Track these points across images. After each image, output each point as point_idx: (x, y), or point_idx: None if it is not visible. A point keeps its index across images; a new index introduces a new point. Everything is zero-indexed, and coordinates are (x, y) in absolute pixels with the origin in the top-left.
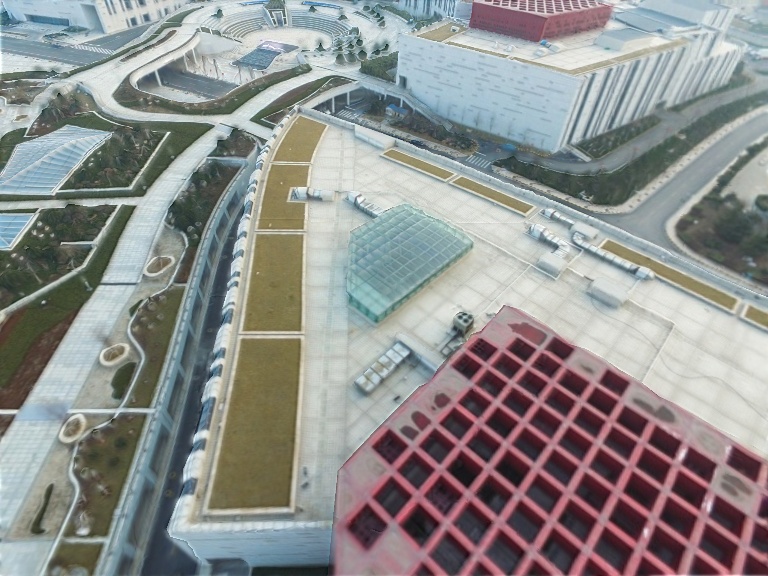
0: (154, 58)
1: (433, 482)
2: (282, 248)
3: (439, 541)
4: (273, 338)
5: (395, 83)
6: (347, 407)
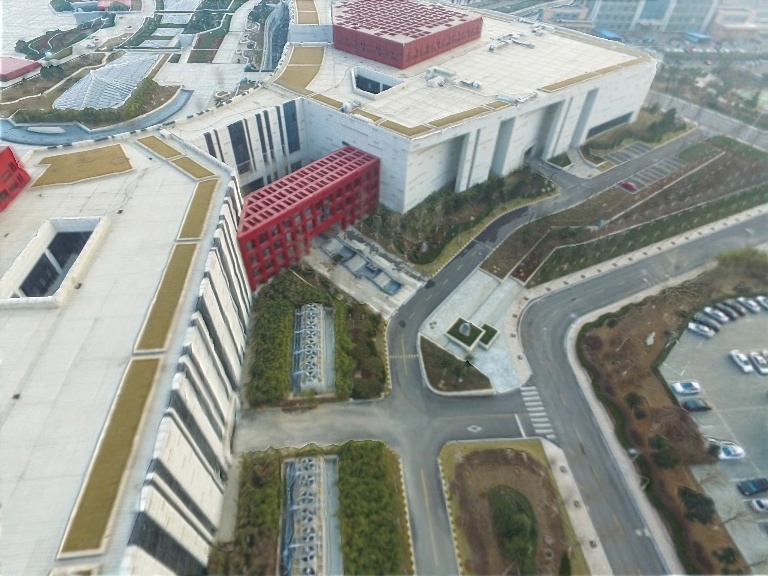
0: None
1: None
2: (306, 1)
3: None
4: (308, 11)
5: None
6: None
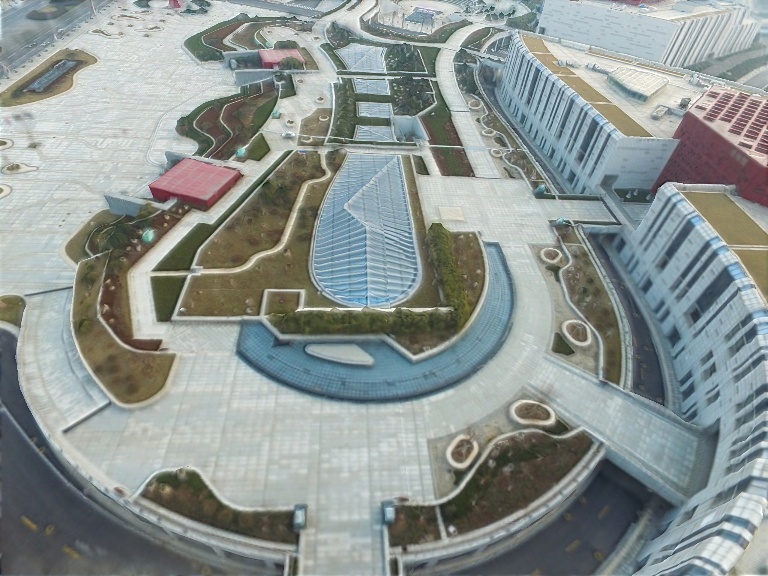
0: (367, 10)
1: (723, 114)
2: (574, 80)
3: (735, 122)
4: (603, 104)
5: None
6: (652, 122)
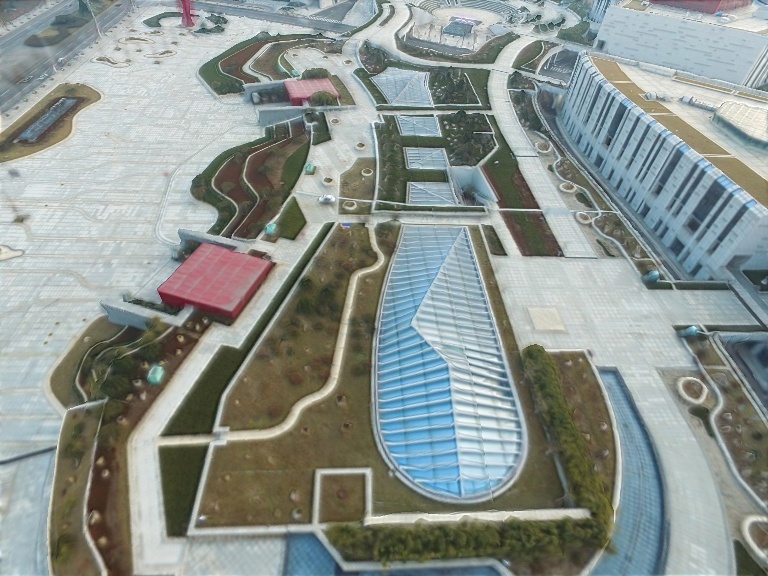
0: (402, 24)
1: None
2: (673, 121)
3: None
4: (721, 157)
5: (592, 46)
6: None
